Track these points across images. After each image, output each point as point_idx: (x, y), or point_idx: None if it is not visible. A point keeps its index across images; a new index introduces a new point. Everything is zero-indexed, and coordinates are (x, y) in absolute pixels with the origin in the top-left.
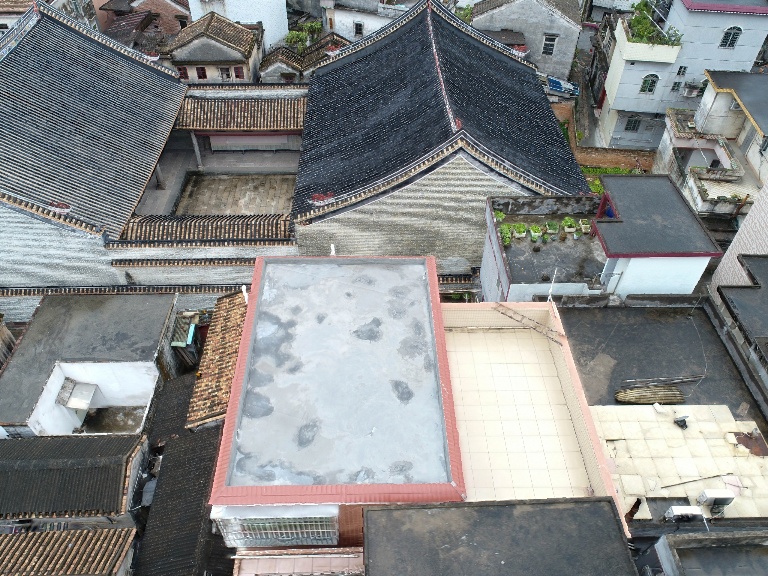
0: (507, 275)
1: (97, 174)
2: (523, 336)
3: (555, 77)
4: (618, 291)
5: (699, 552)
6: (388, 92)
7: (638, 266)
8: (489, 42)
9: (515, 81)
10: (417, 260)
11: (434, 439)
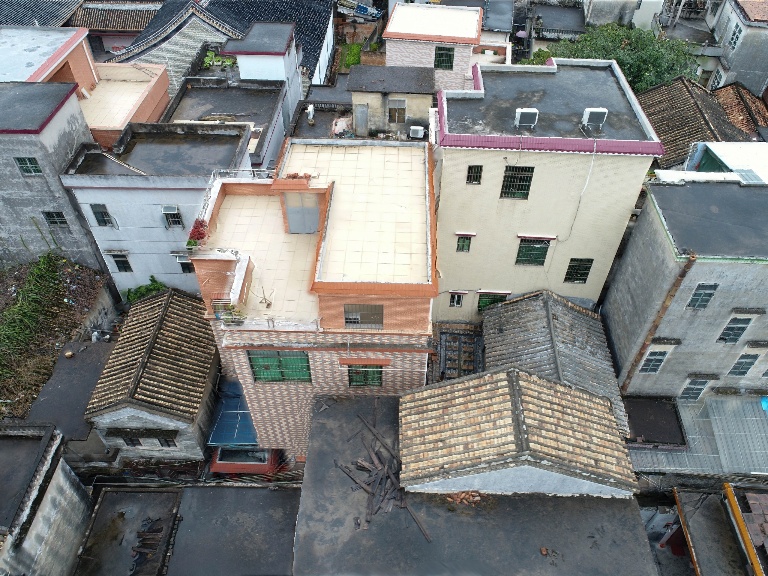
0: None
1: None
2: None
3: (363, 4)
4: None
5: (149, 135)
6: None
7: (243, 62)
8: None
9: None
10: (76, 28)
11: None
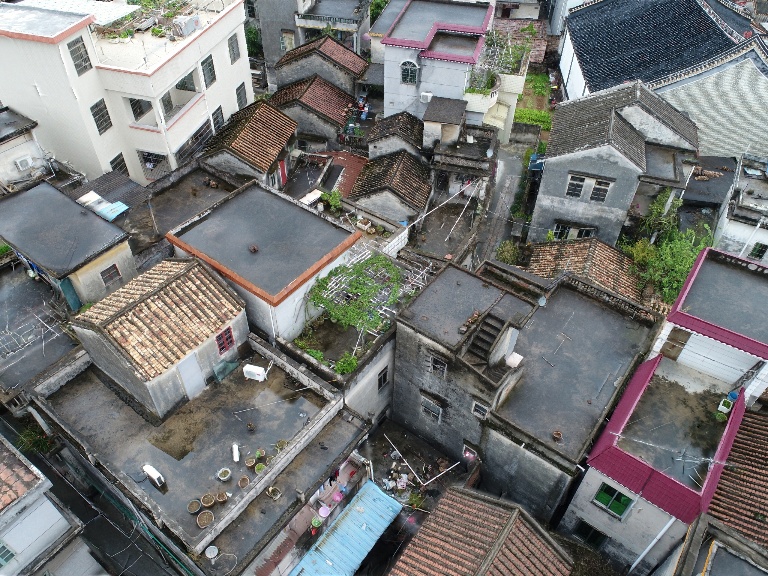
0: None
1: None
2: None
3: None
4: None
5: None
6: None
7: None
8: None
9: None
10: None
11: None
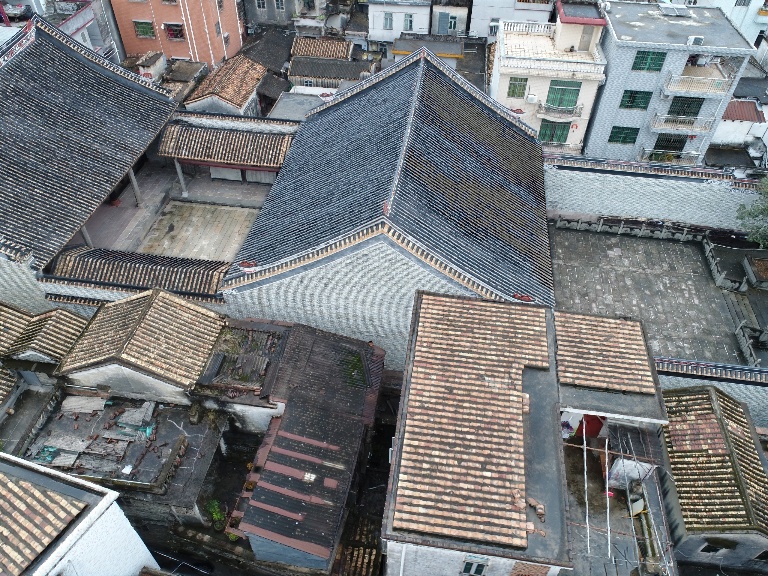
0: (87, 6)
1: None
2: None
3: None
4: None
5: None
6: (5, 144)
7: None
8: None
9: None
10: None
11: None
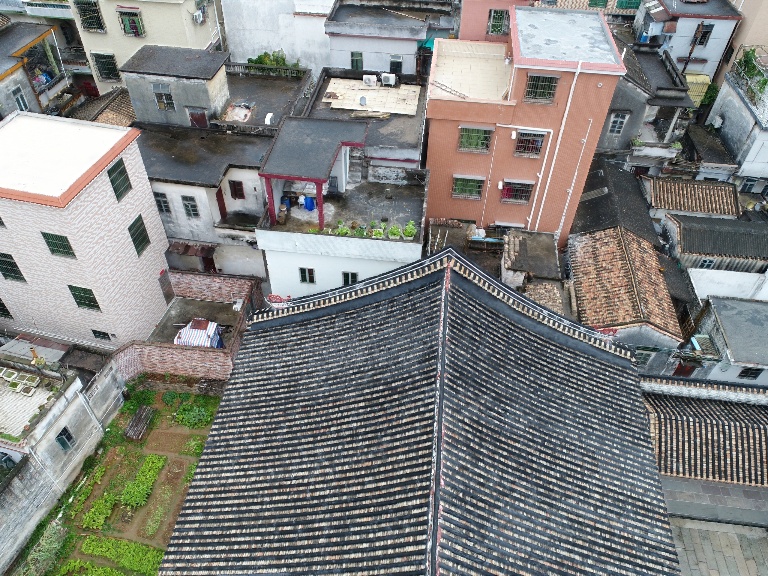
0: None
1: None
2: None
3: None
4: None
5: None
6: None
7: None
8: None
9: None
10: None
11: None
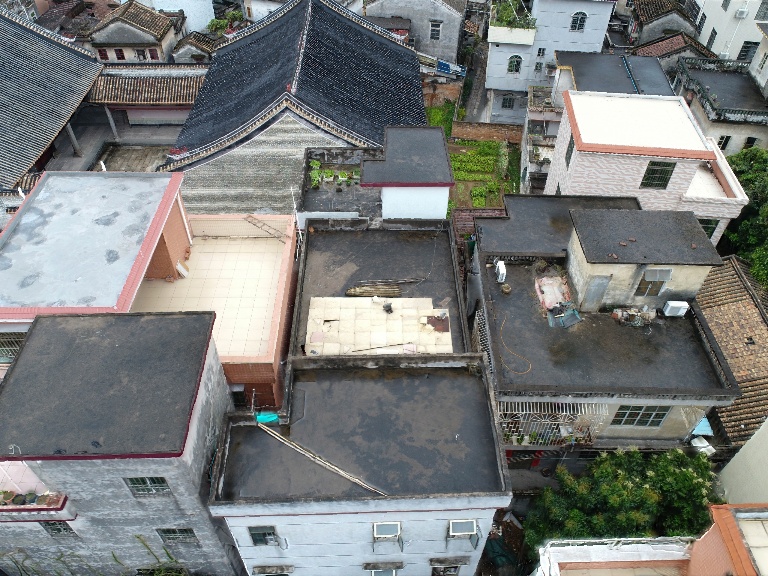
0: None
1: (1, 135)
2: (272, 243)
3: (444, 60)
4: (383, 218)
5: (319, 372)
6: (264, 68)
7: (391, 195)
8: (369, 26)
9: (391, 61)
10: (166, 174)
11: (120, 284)
